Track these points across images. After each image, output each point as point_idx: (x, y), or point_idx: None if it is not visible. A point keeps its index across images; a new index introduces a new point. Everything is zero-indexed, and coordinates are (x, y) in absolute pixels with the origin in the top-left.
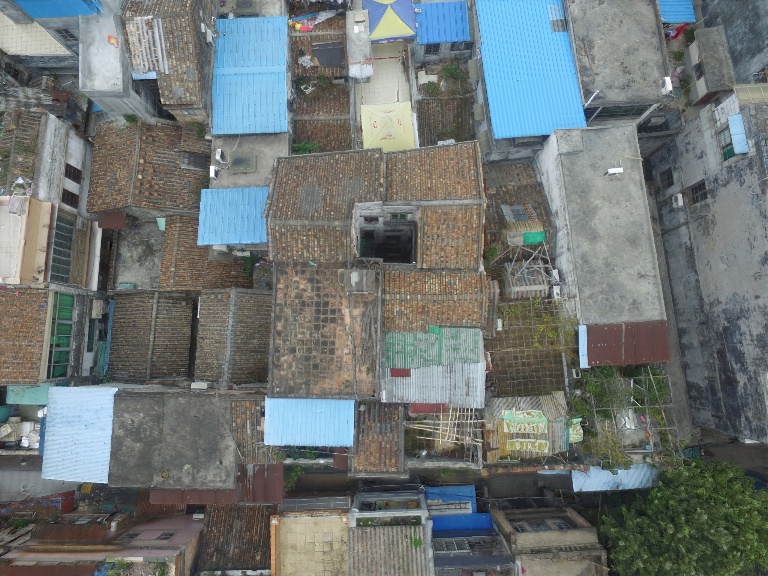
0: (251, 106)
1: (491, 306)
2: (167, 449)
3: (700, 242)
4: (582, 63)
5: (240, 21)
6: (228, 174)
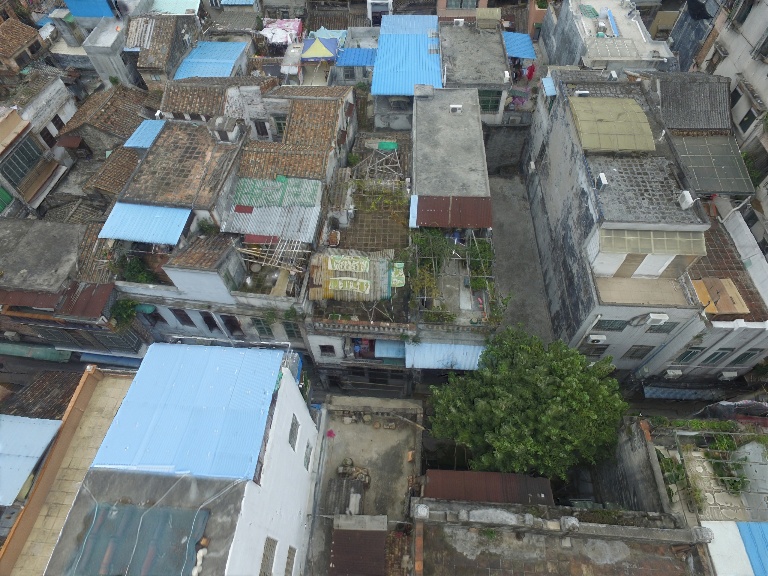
0: None
1: None
2: (14, 257)
3: (546, 187)
4: (446, 66)
5: (215, 43)
6: None
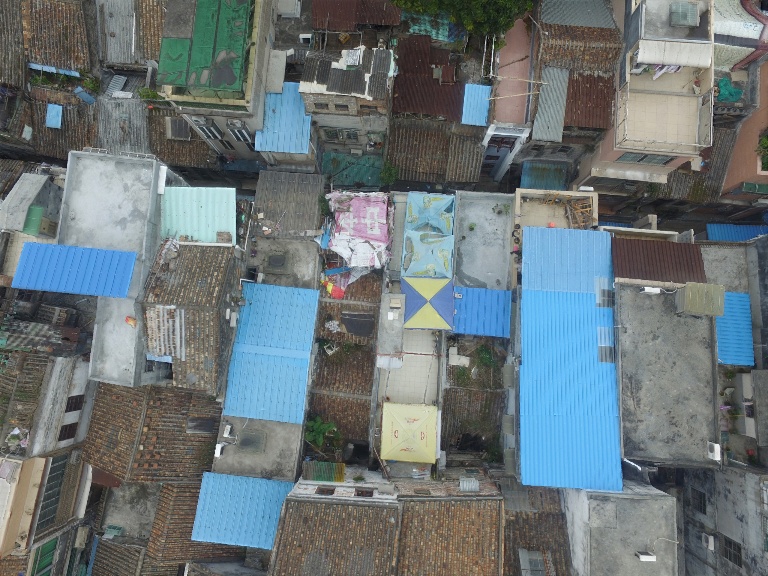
0: (268, 390)
1: None
2: None
3: None
4: (626, 405)
5: (269, 289)
6: (234, 450)
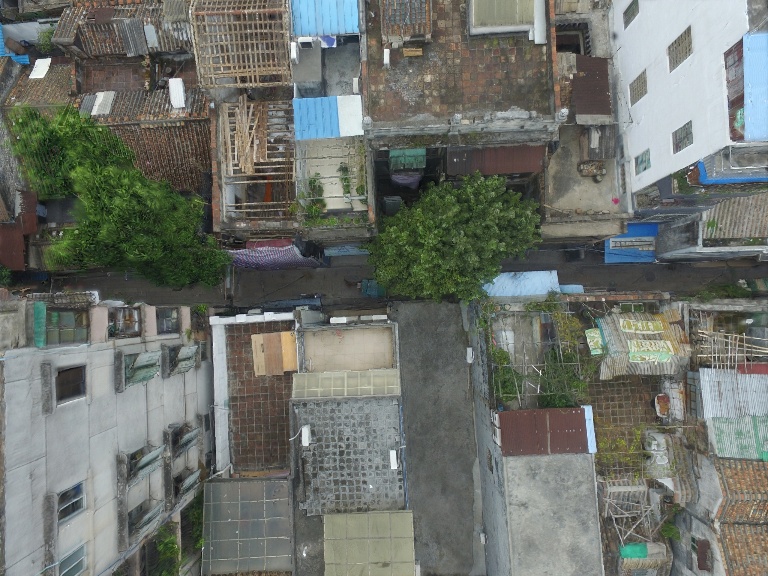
0: None
1: (681, 473)
2: None
3: None
4: None
5: None
6: None
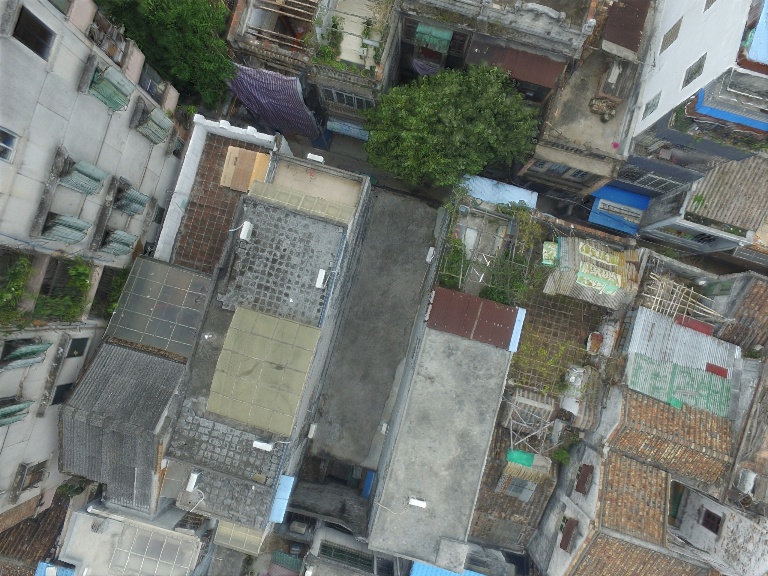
0: None
1: (589, 401)
2: None
3: None
4: None
5: None
6: None
